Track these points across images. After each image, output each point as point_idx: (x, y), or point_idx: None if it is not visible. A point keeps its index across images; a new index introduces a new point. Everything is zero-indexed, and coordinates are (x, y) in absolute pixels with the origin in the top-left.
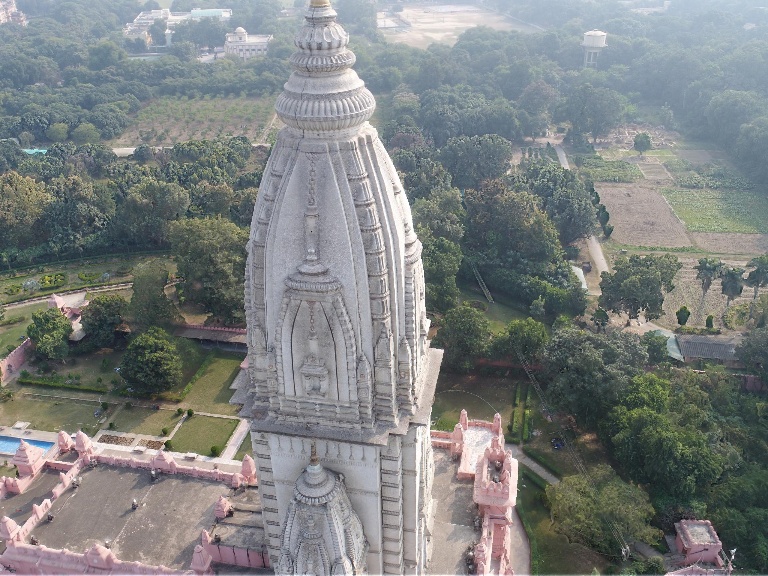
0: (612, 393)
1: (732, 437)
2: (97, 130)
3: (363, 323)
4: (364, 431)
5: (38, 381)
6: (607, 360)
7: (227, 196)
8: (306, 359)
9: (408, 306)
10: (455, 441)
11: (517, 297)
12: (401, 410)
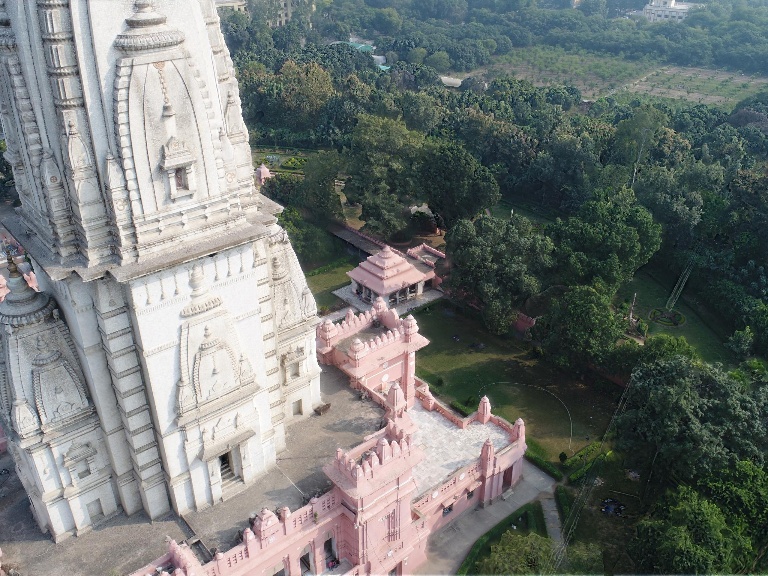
0: (686, 464)
1: None
2: (450, 60)
3: (45, 106)
4: (56, 257)
5: None
6: (711, 417)
7: (482, 126)
8: (8, 141)
9: (115, 107)
10: (387, 403)
11: (732, 324)
12: (115, 255)
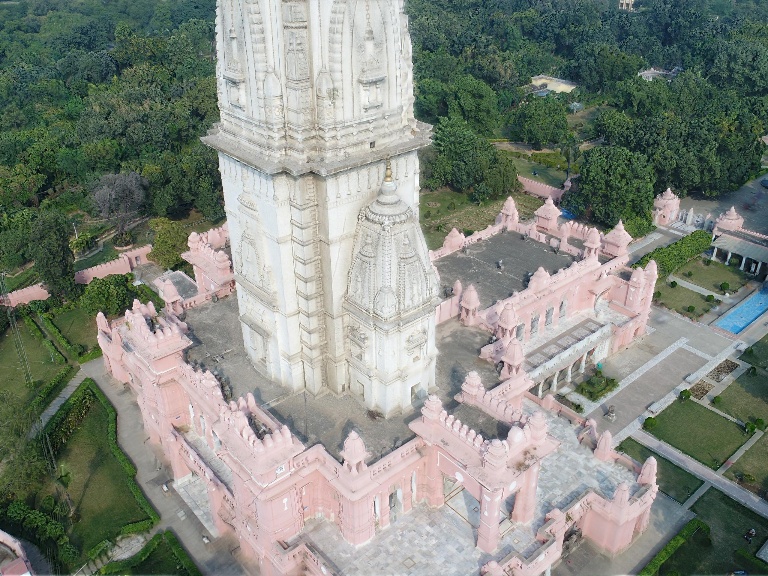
0: None
1: None
2: None
3: None
4: None
5: None
6: None
7: None
8: None
9: None
10: None
11: None
12: None
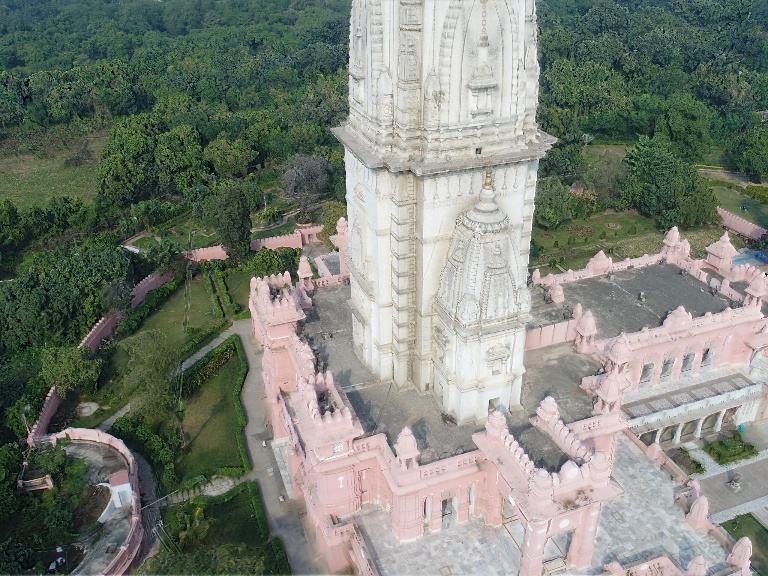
0: None
1: None
2: None
3: None
4: None
5: None
6: None
7: None
8: None
9: None
10: None
11: None
12: None
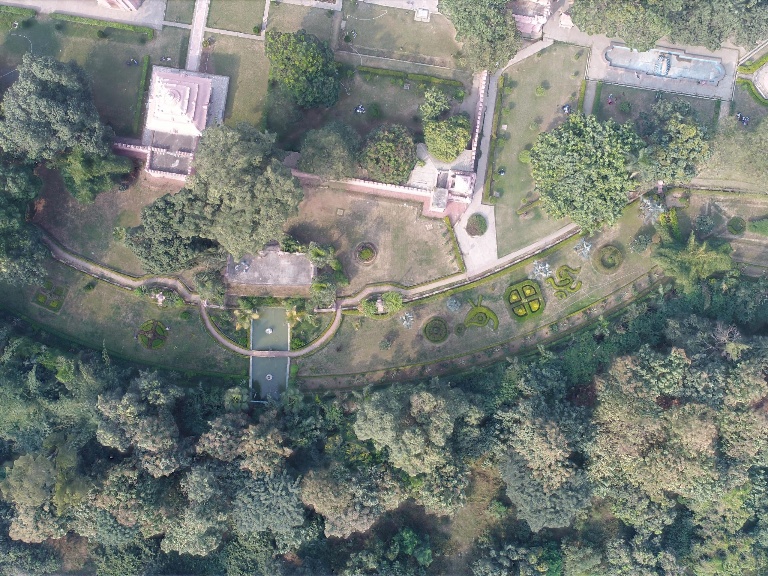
0: None
1: None
2: None
3: None
4: None
5: (438, 81)
6: None
7: None
8: None
9: None
10: None
11: None
12: None
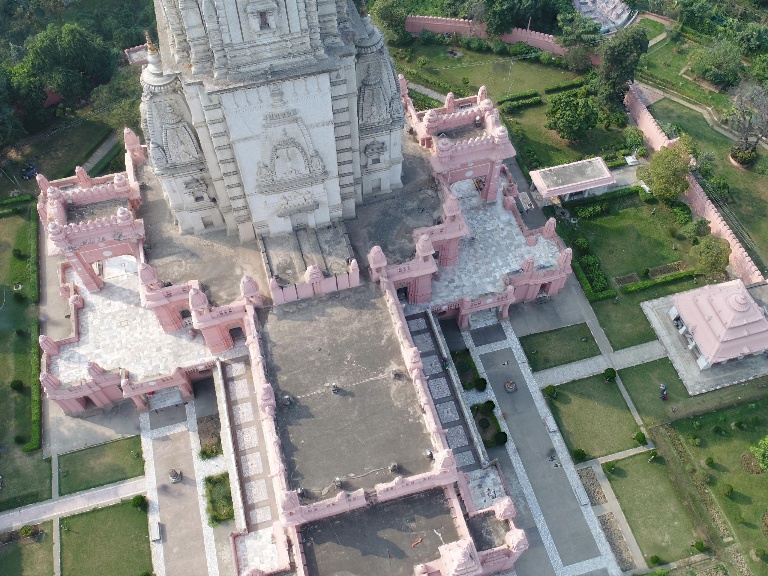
0: None
1: (8, 48)
2: None
3: None
4: None
5: None
6: None
7: None
8: None
9: None
10: None
11: None
12: None
